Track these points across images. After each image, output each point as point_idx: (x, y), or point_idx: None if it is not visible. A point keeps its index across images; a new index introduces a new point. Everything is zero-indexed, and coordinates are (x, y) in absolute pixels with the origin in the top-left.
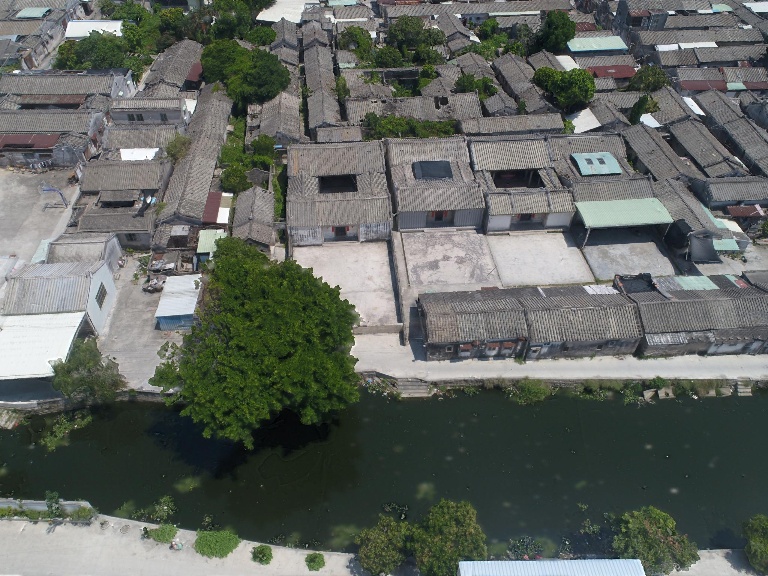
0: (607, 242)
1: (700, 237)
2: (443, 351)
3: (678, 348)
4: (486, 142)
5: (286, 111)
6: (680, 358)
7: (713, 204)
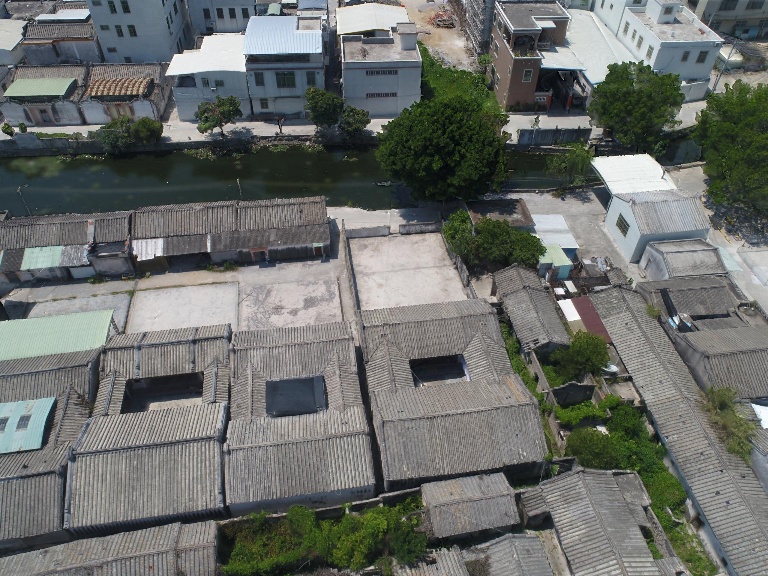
0: None
1: None
2: None
3: None
4: None
5: (609, 574)
6: None
7: None
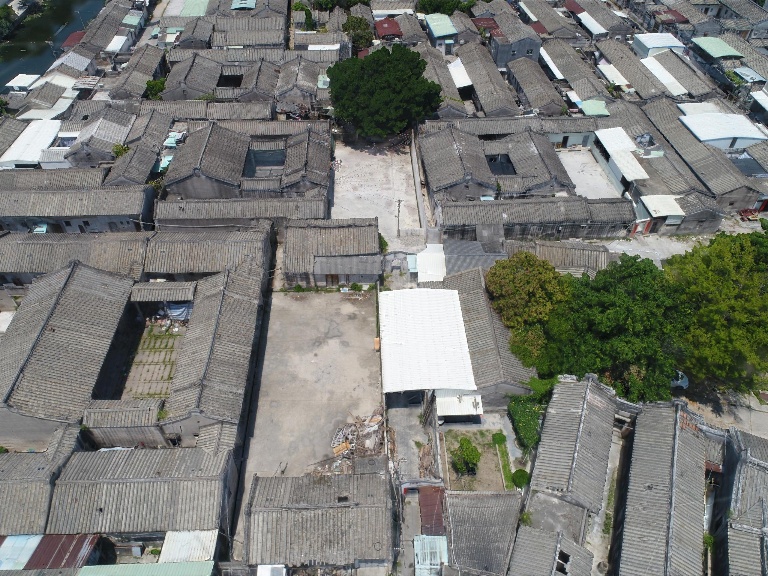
0: None
1: None
2: None
3: None
4: None
5: None
6: None
7: None
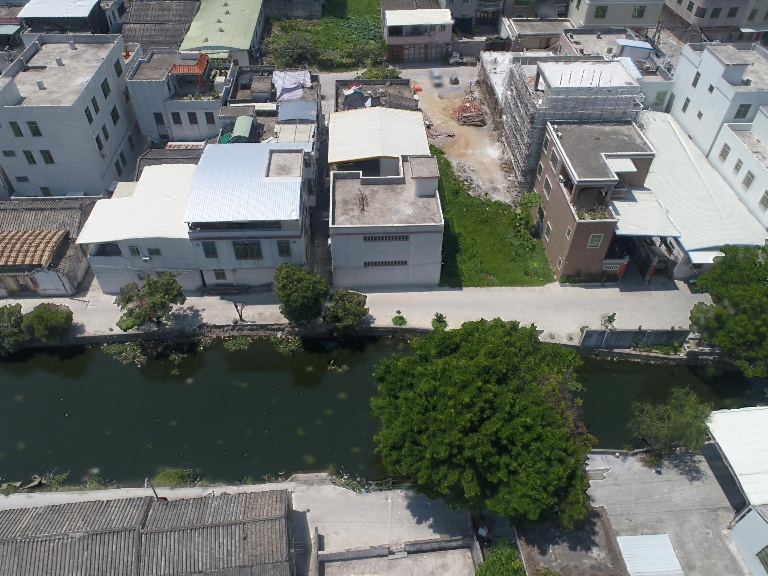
0: None
1: None
2: None
3: None
4: None
5: None
6: None
7: None
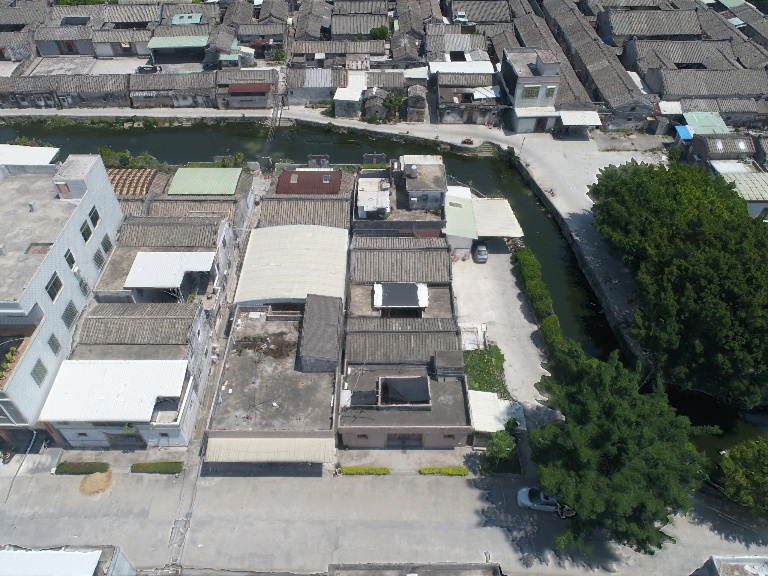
0: (173, 63)
1: (213, 52)
2: (9, 100)
3: (153, 101)
4: (117, 6)
5: None
6: (158, 109)
7: (245, 39)
